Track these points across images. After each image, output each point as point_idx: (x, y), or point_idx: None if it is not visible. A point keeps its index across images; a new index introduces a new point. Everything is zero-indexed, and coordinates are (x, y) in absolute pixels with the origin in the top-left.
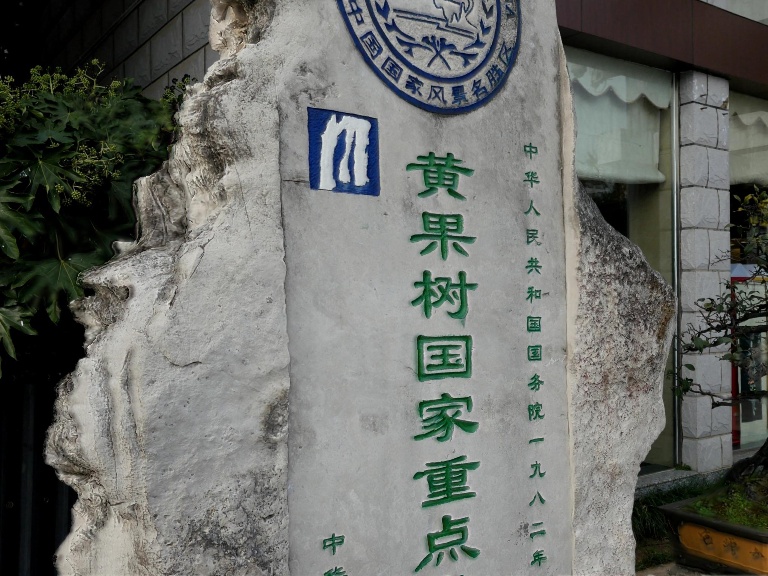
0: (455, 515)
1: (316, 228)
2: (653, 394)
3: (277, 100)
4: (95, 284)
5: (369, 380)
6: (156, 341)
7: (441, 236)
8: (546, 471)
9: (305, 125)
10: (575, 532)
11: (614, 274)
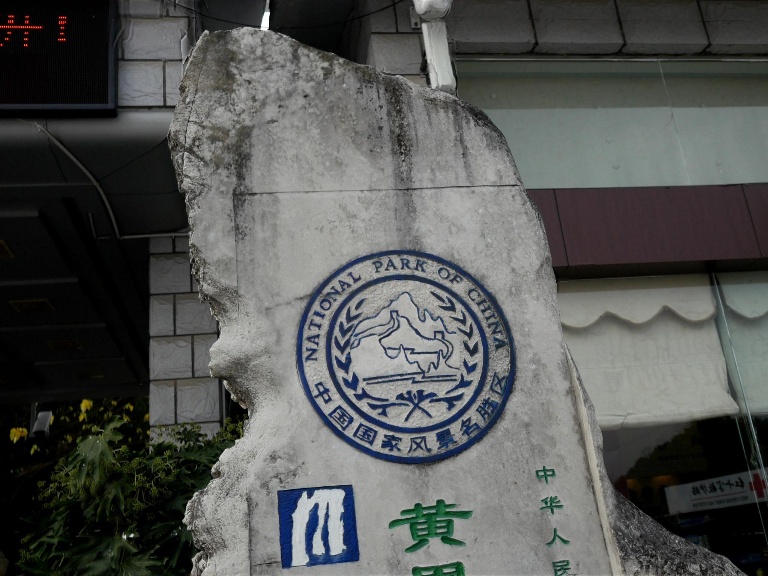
0: None
1: None
2: None
3: (247, 492)
4: None
5: None
6: None
7: None
8: None
9: (275, 508)
10: None
11: None
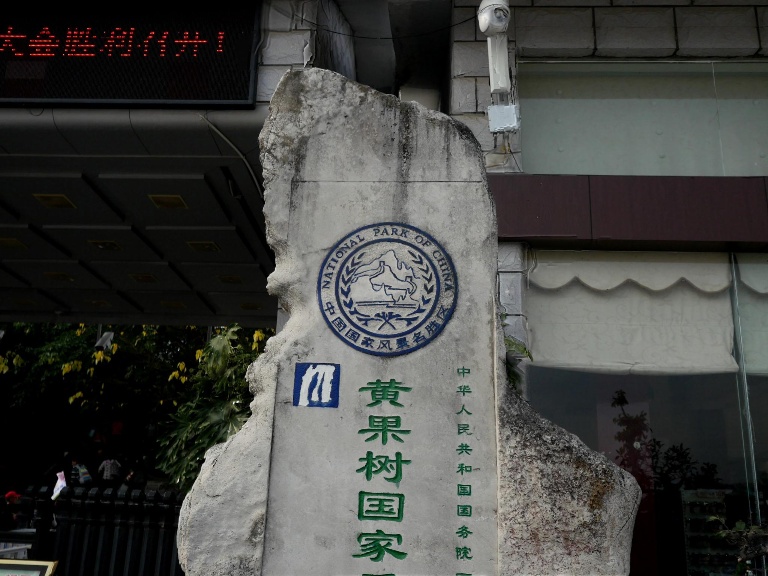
0: None
1: (294, 427)
2: (599, 556)
3: (279, 361)
4: None
5: (321, 515)
6: (203, 483)
7: (383, 430)
8: None
9: (293, 372)
10: None
11: (535, 455)
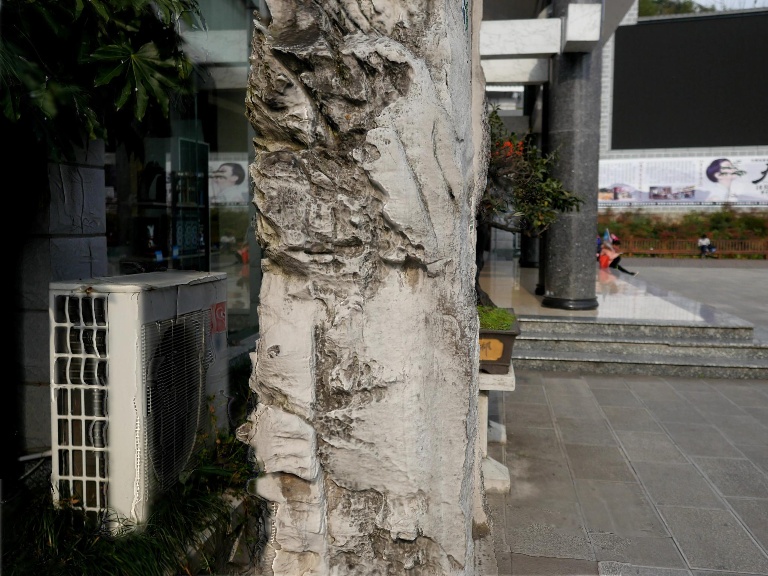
0: None
1: None
2: None
3: None
4: (345, 59)
5: None
6: None
7: None
8: None
9: None
10: None
11: (487, 123)
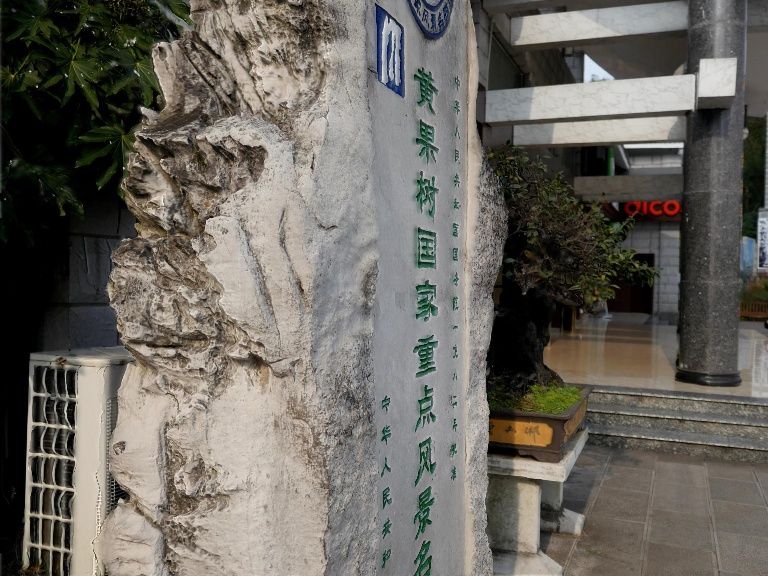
0: (429, 385)
1: (380, 117)
2: None
3: None
4: (199, 144)
5: None
6: (310, 202)
7: None
8: (458, 354)
9: (375, 19)
10: (468, 404)
11: (493, 196)
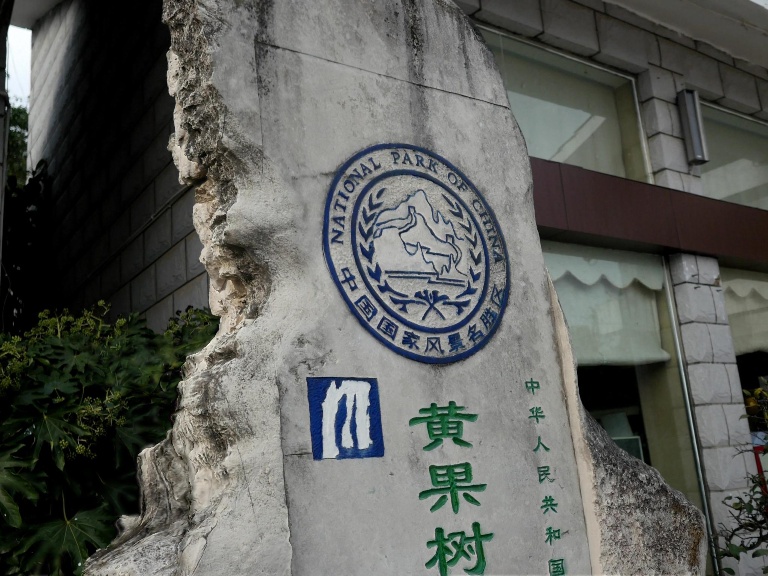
0: None
1: (321, 500)
2: None
3: (276, 375)
4: None
5: None
6: None
7: (450, 488)
8: None
9: (305, 396)
10: None
11: (633, 503)
